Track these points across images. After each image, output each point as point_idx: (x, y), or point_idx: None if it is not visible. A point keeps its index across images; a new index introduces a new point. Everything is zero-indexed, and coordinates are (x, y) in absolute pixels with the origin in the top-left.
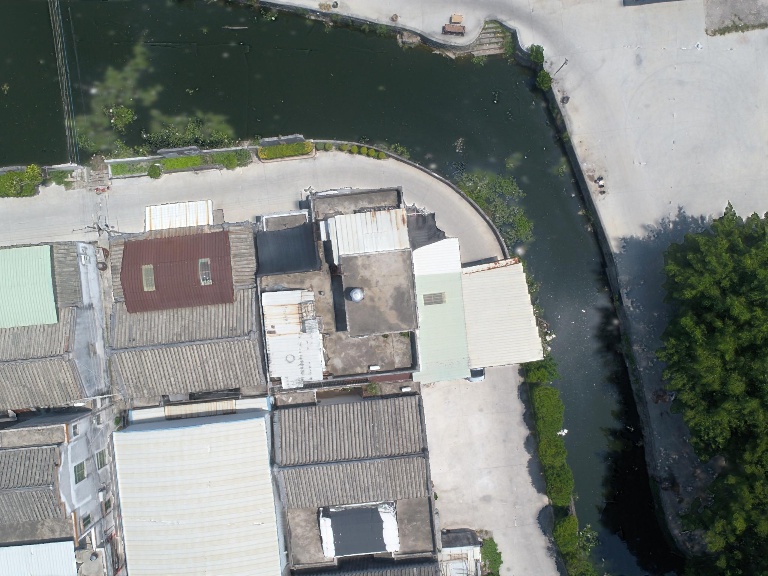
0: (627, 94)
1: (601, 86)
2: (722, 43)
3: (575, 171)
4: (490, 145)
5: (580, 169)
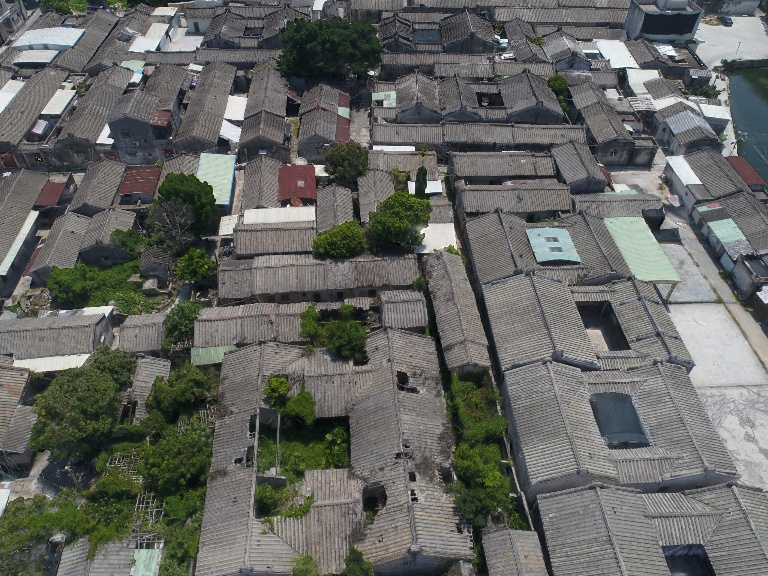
0: (730, 48)
1: (730, 52)
2: (699, 32)
3: (764, 65)
4: (765, 81)
5: (767, 59)
